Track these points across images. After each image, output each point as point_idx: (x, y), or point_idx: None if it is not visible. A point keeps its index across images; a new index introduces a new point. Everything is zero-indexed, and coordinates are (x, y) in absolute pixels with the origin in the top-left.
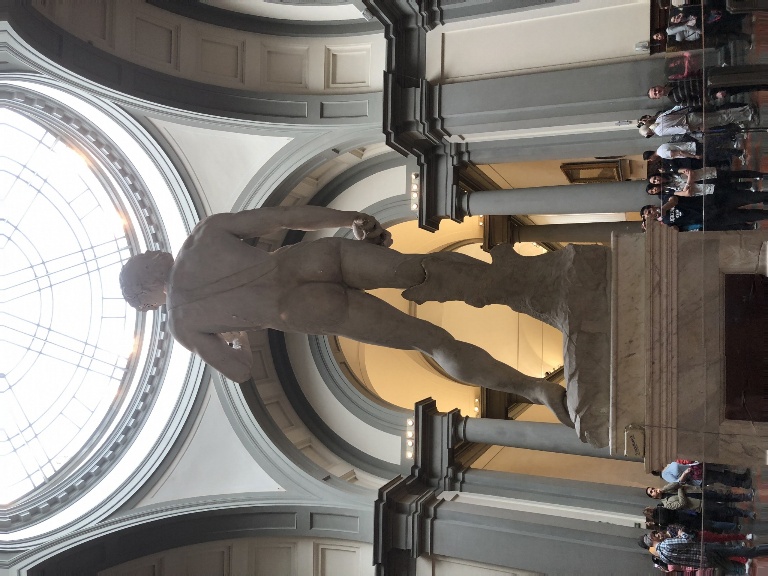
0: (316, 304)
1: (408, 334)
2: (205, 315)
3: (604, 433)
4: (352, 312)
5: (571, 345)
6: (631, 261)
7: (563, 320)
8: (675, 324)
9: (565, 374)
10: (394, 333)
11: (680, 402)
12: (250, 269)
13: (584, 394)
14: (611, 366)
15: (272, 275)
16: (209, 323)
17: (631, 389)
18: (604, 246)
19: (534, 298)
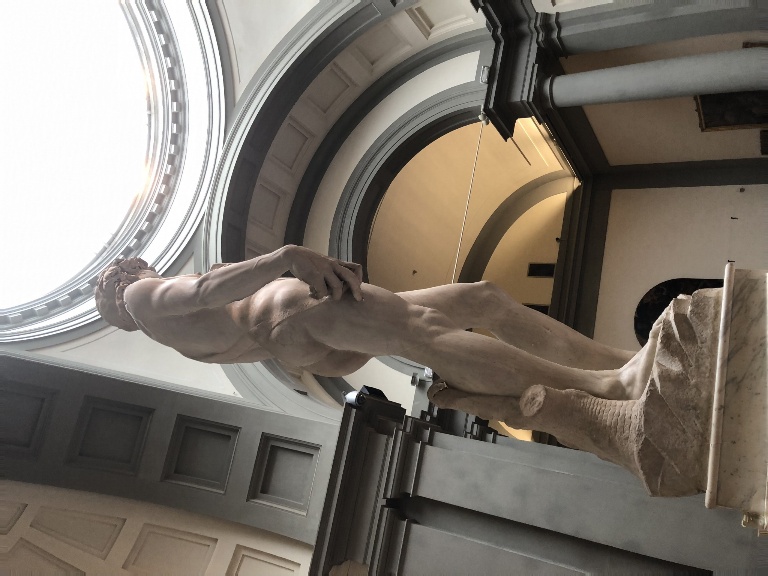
0: None
1: None
2: None
3: None
4: None
5: None
6: None
7: None
8: None
9: None
10: None
11: None
12: (233, 348)
13: None
14: None
15: None
16: None
17: None
18: (696, 470)
19: None
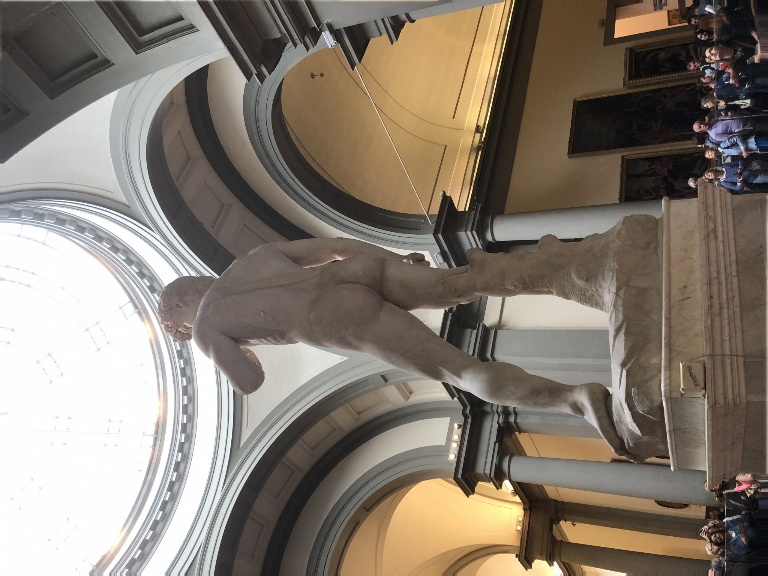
0: (350, 297)
1: (437, 350)
2: (234, 310)
3: (655, 387)
4: (384, 315)
5: (618, 300)
6: (684, 220)
7: (610, 281)
8: (734, 268)
9: (610, 336)
10: (423, 345)
11: (746, 341)
12: (293, 274)
13: (632, 345)
14: (663, 309)
15: (312, 282)
16: (235, 320)
17: (687, 331)
18: None
19: (580, 265)
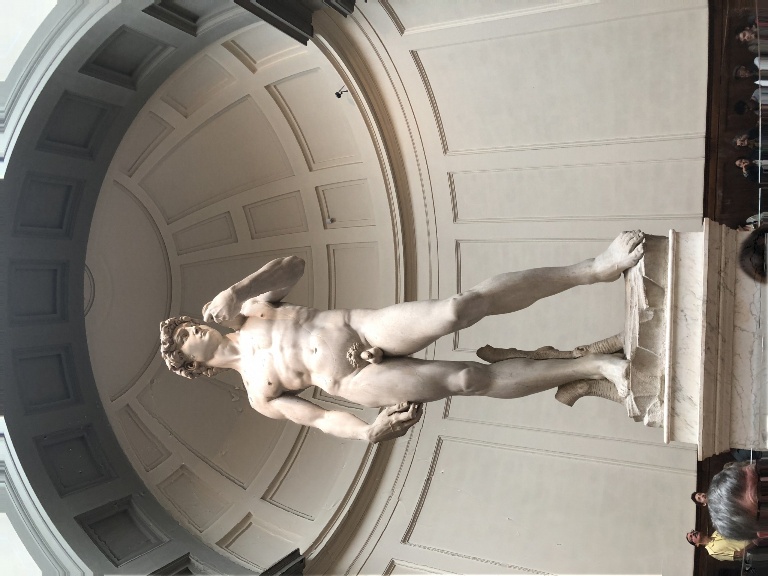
0: None
1: None
2: None
3: None
4: None
5: None
6: None
7: None
8: None
9: None
10: None
11: None
12: None
13: None
14: None
15: None
16: None
17: None
18: None
19: None
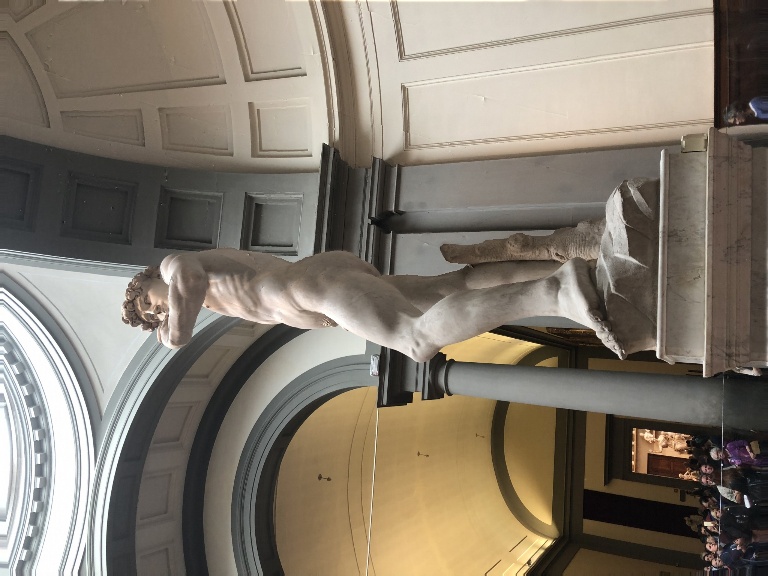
0: None
1: (406, 302)
2: None
3: None
4: (366, 273)
5: None
6: None
7: None
8: None
9: None
10: (393, 294)
11: None
12: None
13: None
14: None
15: None
16: (218, 253)
17: None
18: None
19: None
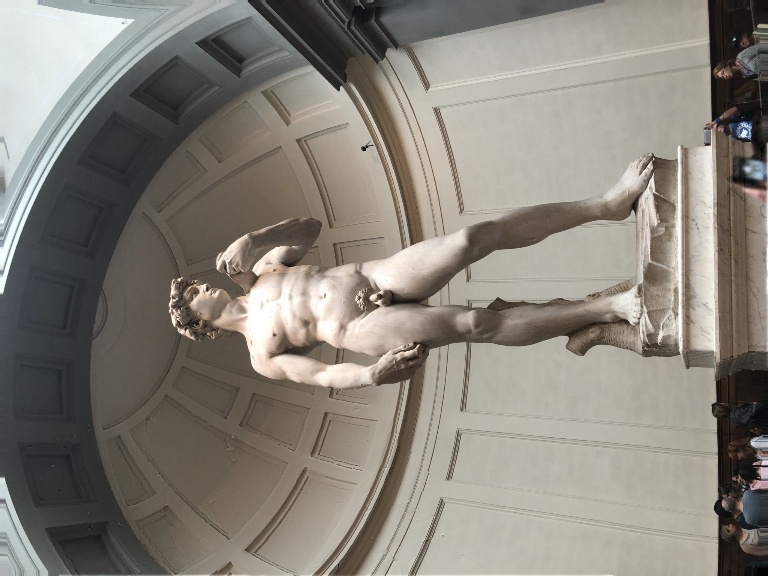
0: None
1: None
2: None
3: None
4: None
5: None
6: None
7: None
8: None
9: None
10: None
11: None
12: None
13: None
14: None
15: None
16: None
17: None
18: None
19: None
